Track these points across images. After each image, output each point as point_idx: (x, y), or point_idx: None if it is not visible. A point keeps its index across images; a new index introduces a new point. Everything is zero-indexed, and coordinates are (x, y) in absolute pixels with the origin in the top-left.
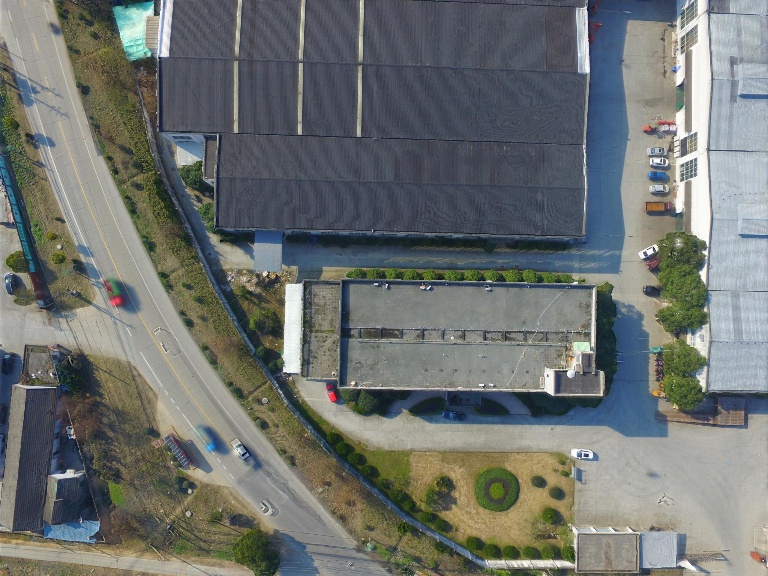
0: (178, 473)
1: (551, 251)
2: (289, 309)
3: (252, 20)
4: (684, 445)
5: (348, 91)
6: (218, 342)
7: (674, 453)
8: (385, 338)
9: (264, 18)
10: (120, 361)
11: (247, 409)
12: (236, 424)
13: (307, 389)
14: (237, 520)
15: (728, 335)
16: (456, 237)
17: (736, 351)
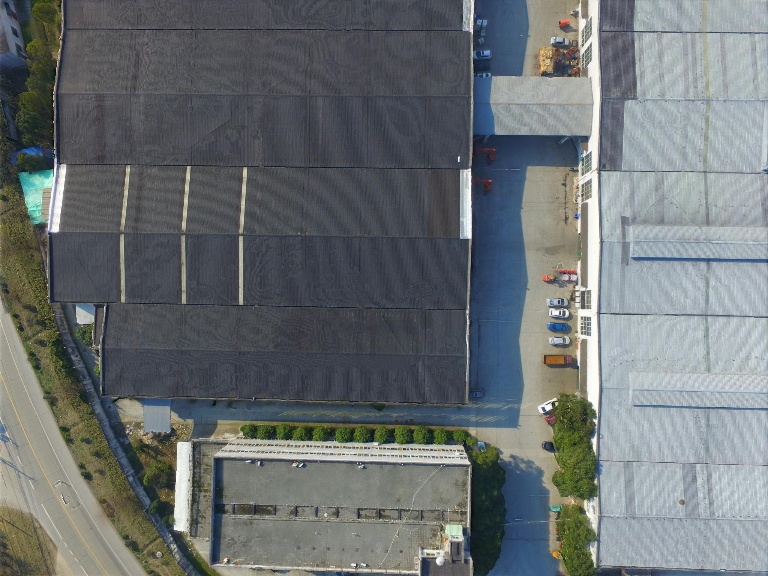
0: None
1: None
2: (180, 467)
3: (138, 193)
4: None
5: (230, 260)
6: (115, 495)
7: None
8: (258, 514)
9: (150, 190)
10: (23, 512)
11: (142, 562)
12: None
13: (201, 542)
14: None
15: (619, 510)
16: None
17: (628, 526)
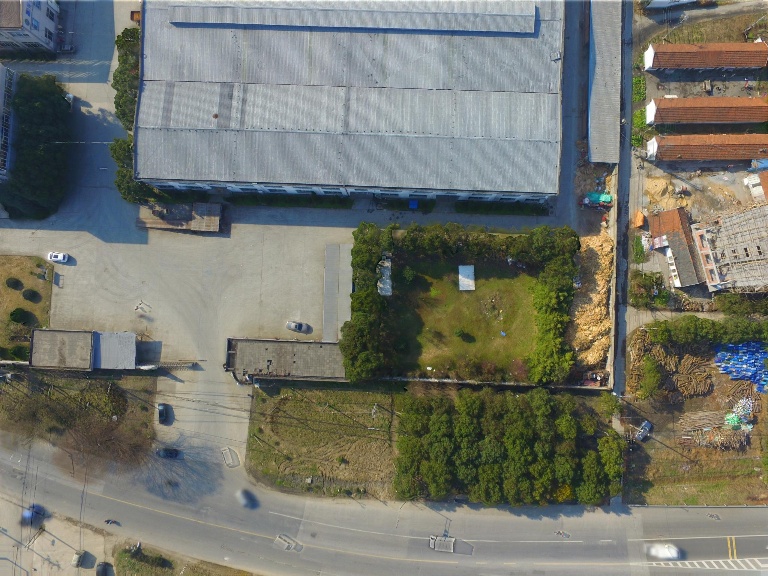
0: None
1: (42, 61)
2: None
3: None
4: (164, 253)
5: None
6: None
7: (154, 260)
8: None
9: None
10: None
11: None
12: None
13: None
14: None
15: (155, 122)
16: None
17: (163, 138)
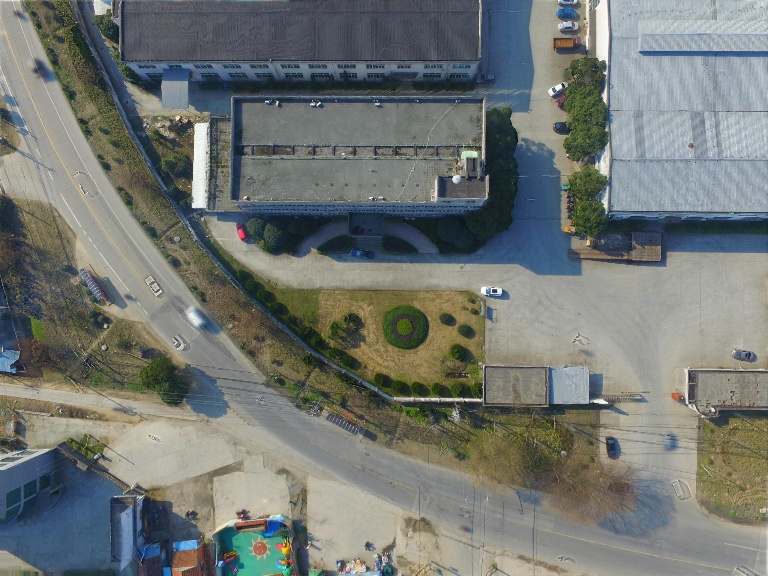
0: (95, 309)
1: (459, 91)
2: (197, 147)
3: None
4: (599, 284)
5: None
6: (133, 184)
7: (588, 292)
8: (277, 155)
9: None
10: (42, 203)
11: (160, 248)
12: (150, 262)
13: (218, 229)
14: (150, 354)
15: (630, 153)
16: (362, 79)
17: (639, 170)
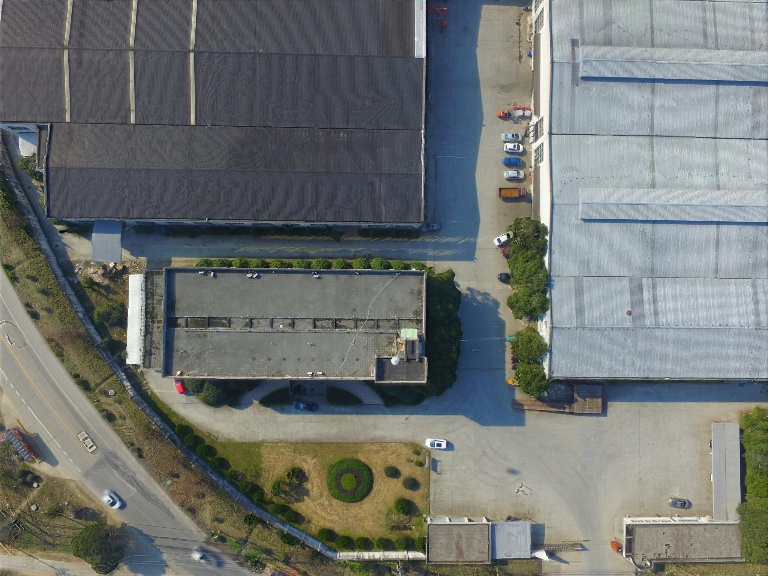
0: (24, 466)
1: (404, 239)
2: (132, 300)
3: (83, 9)
4: (542, 434)
5: (181, 79)
6: (64, 334)
7: (532, 442)
8: (212, 327)
9: (95, 6)
10: None
11: (94, 401)
12: (83, 417)
13: (156, 381)
14: (83, 513)
15: (570, 321)
16: (306, 226)
17: (578, 337)
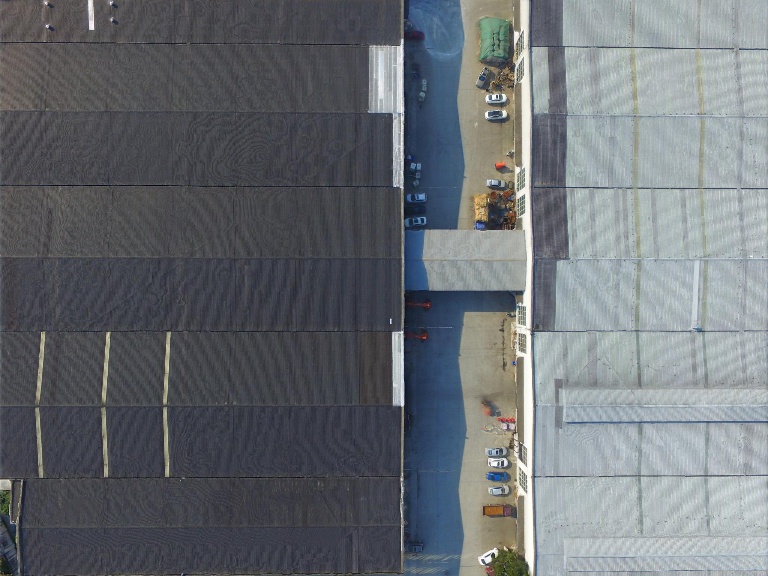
0: None
1: None
2: None
3: (54, 362)
4: None
5: (155, 431)
6: None
7: None
8: None
9: (67, 359)
10: None
11: None
12: None
13: None
14: None
15: None
16: None
17: None
